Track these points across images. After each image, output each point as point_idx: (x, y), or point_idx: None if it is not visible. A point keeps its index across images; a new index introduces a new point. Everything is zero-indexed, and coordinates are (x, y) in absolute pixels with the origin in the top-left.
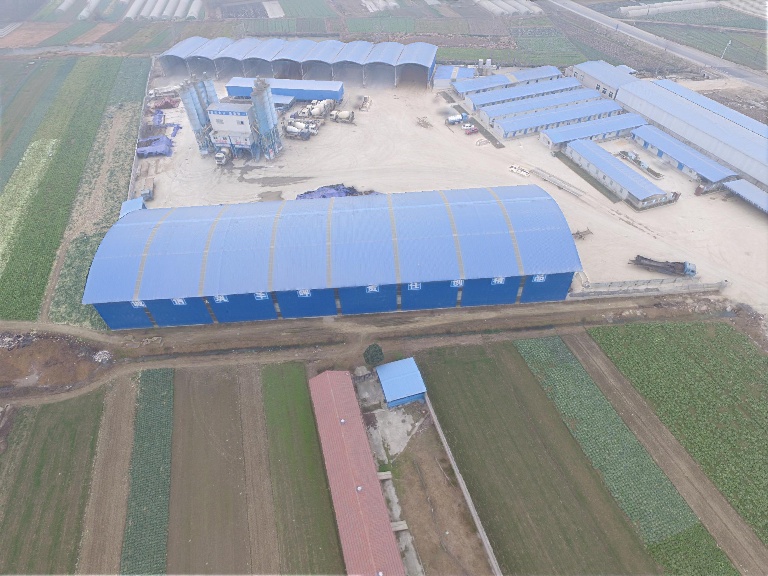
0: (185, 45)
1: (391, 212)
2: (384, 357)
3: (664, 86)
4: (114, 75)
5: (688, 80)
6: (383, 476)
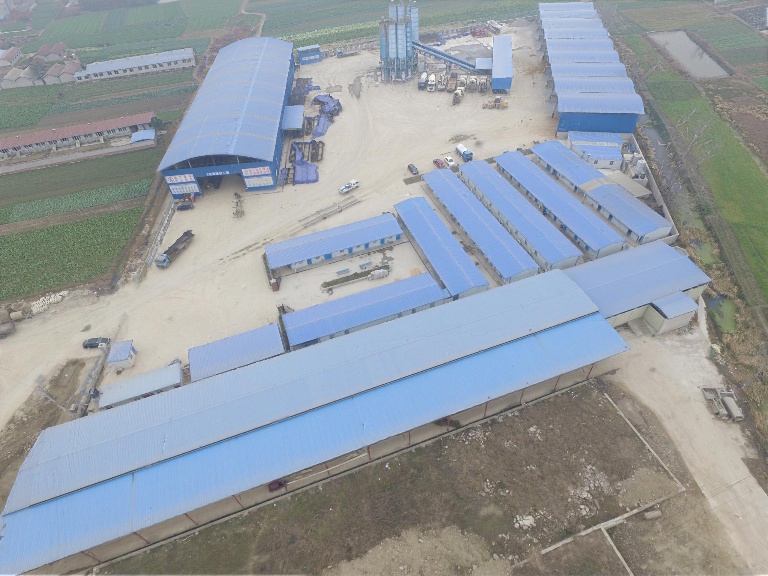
0: (567, 4)
1: (242, 97)
2: (168, 137)
3: (580, 328)
4: (534, 8)
5: (742, 447)
6: (101, 139)
